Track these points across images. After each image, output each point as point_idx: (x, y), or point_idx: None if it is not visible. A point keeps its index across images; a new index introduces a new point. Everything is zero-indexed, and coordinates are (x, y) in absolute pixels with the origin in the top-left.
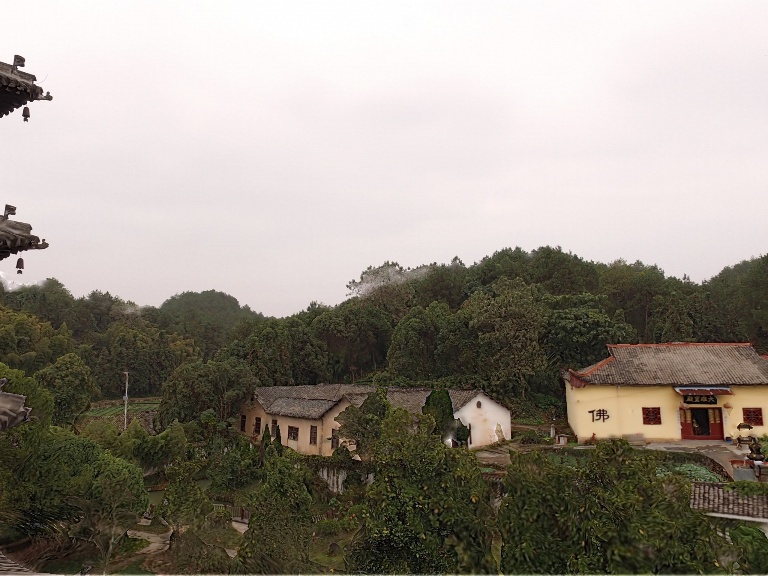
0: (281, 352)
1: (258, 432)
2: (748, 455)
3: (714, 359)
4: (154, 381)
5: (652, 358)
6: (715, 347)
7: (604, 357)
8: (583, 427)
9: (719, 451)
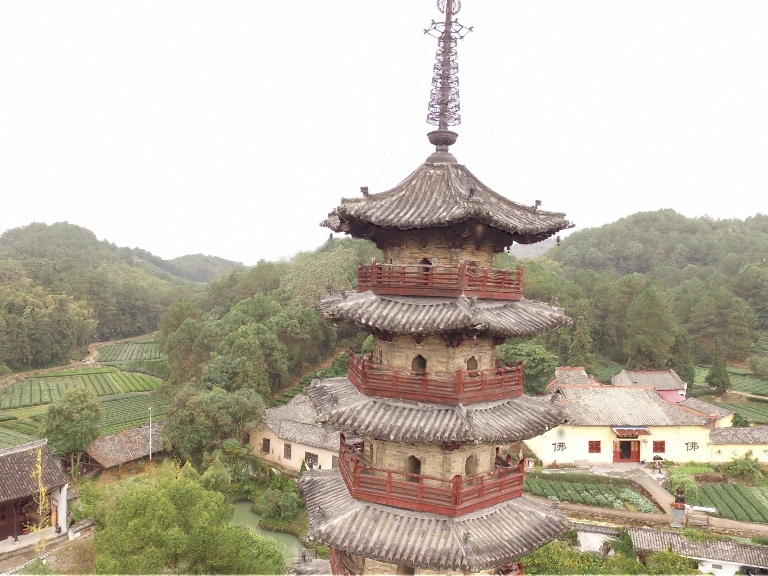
0: (259, 364)
1: (267, 451)
2: (675, 495)
3: (634, 401)
4: (56, 351)
5: (592, 400)
6: (632, 389)
7: (543, 383)
8: (548, 455)
9: (642, 476)
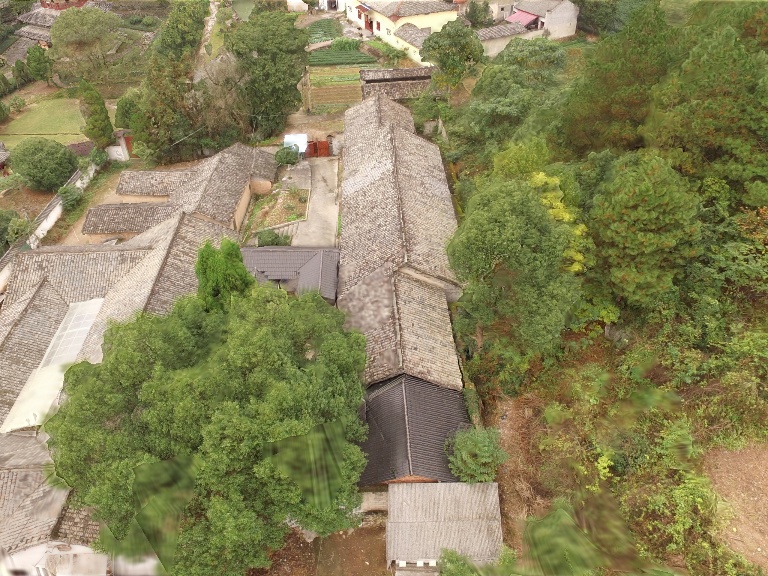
0: None
1: None
2: None
3: None
4: None
5: None
6: None
7: None
8: (347, 13)
9: None
